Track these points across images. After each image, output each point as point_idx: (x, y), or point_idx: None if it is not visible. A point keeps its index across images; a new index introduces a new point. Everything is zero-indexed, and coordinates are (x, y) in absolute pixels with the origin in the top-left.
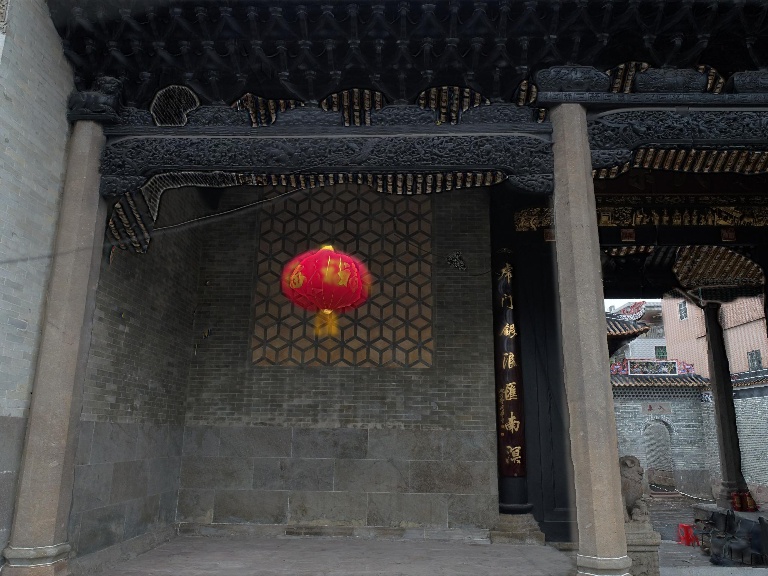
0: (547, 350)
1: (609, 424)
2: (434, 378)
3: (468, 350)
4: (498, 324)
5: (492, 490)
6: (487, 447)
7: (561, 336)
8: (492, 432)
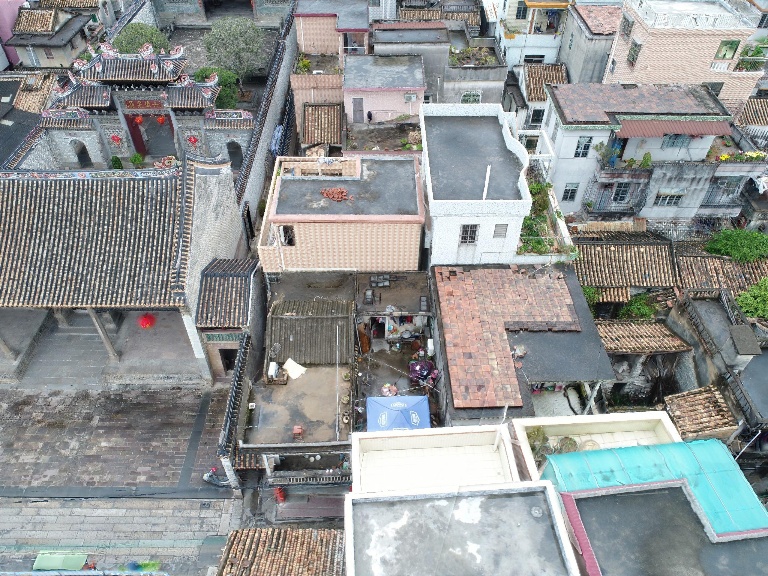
0: None
1: (0, 341)
2: None
3: None
4: None
5: None
6: None
7: None
8: None
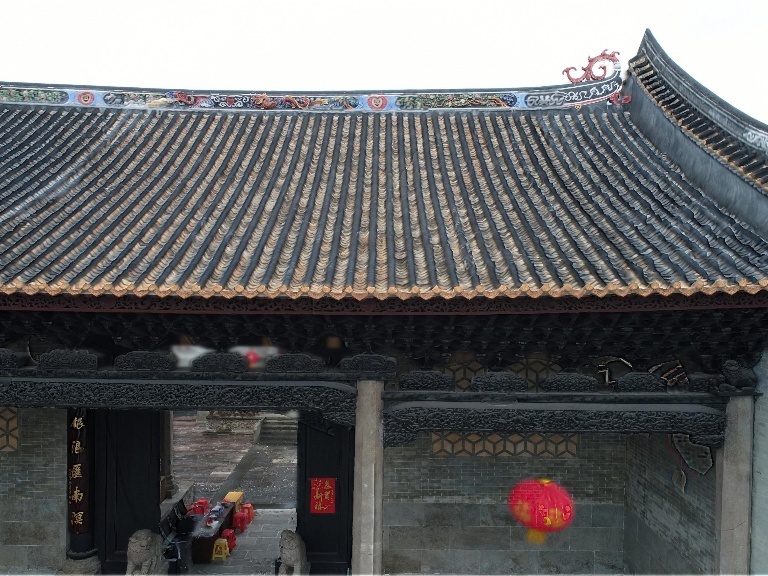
0: (118, 433)
1: None
2: (19, 459)
3: (46, 437)
4: (72, 416)
5: (61, 542)
6: (59, 511)
7: (129, 422)
8: (63, 500)
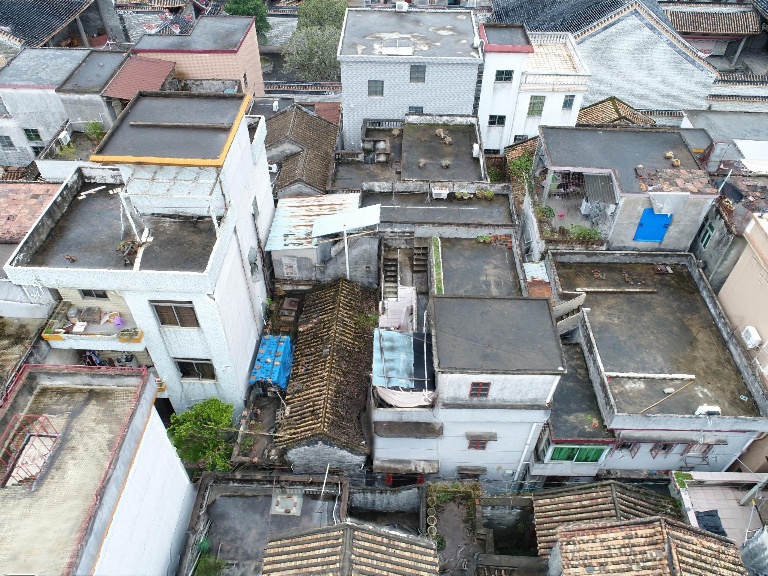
0: None
1: None
2: None
3: None
4: None
5: None
6: None
7: None
8: None
